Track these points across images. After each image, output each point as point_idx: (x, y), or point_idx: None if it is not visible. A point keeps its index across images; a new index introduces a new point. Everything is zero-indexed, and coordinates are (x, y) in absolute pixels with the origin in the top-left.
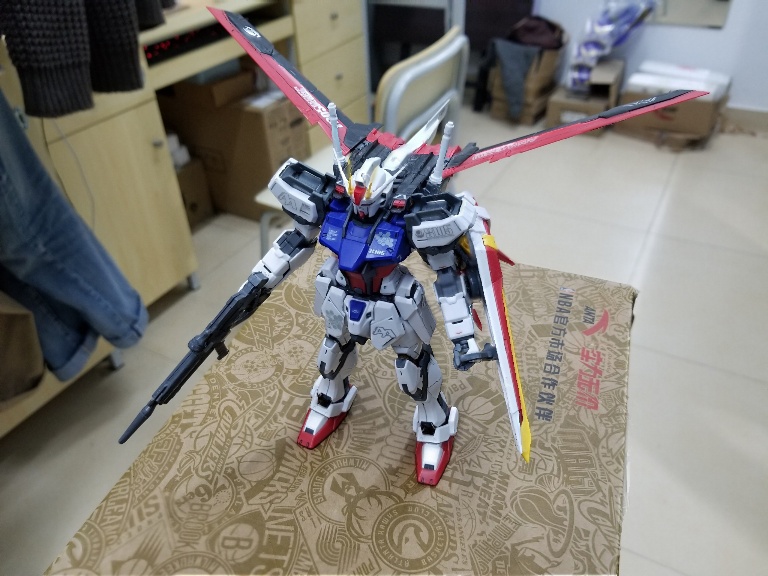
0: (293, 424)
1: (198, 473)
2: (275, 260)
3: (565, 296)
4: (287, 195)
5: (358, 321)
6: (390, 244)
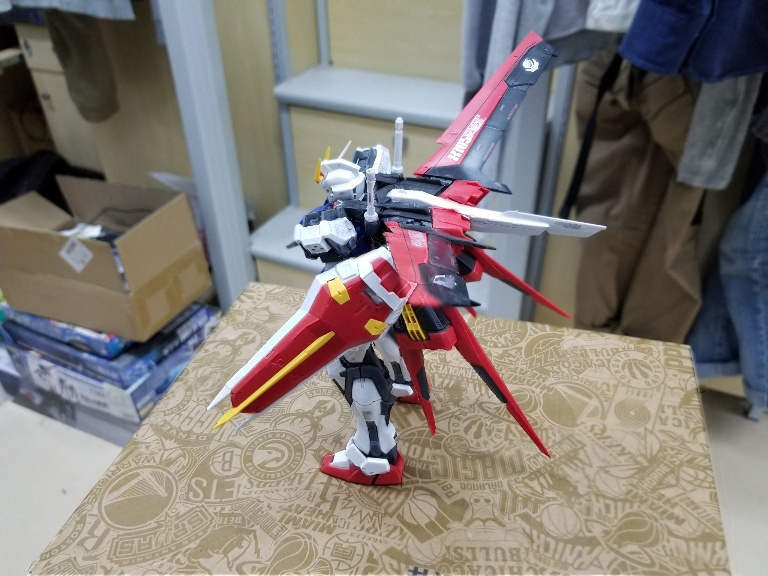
0: None
1: None
2: None
3: None
4: None
5: None
6: None
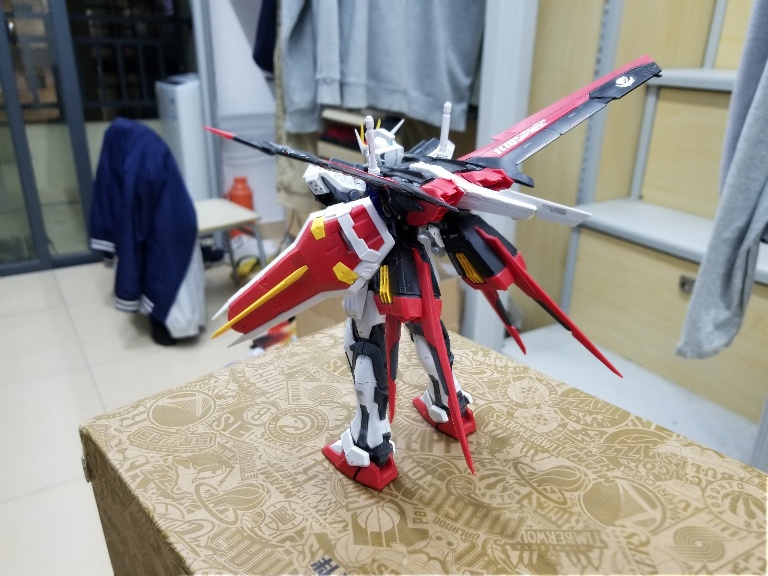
0: None
1: None
2: None
3: None
4: None
5: None
6: None
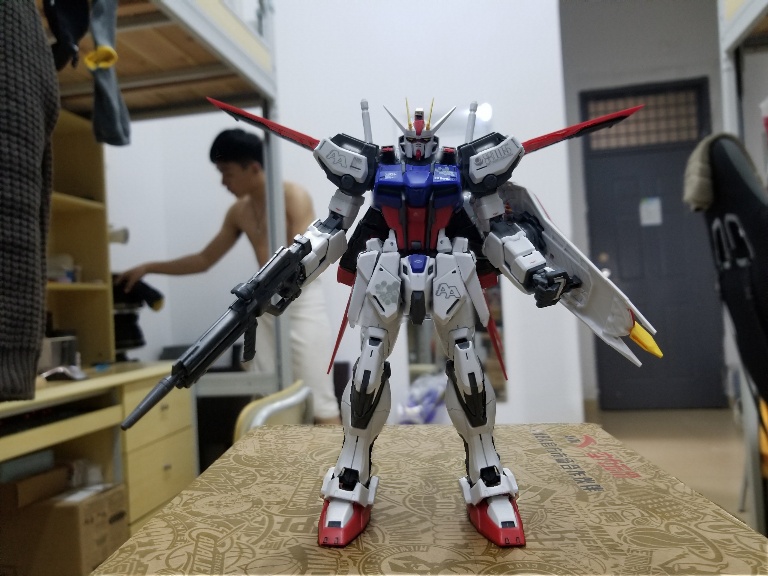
0: (303, 535)
1: None
2: (314, 239)
3: (539, 434)
4: (337, 152)
5: (422, 272)
6: (452, 174)
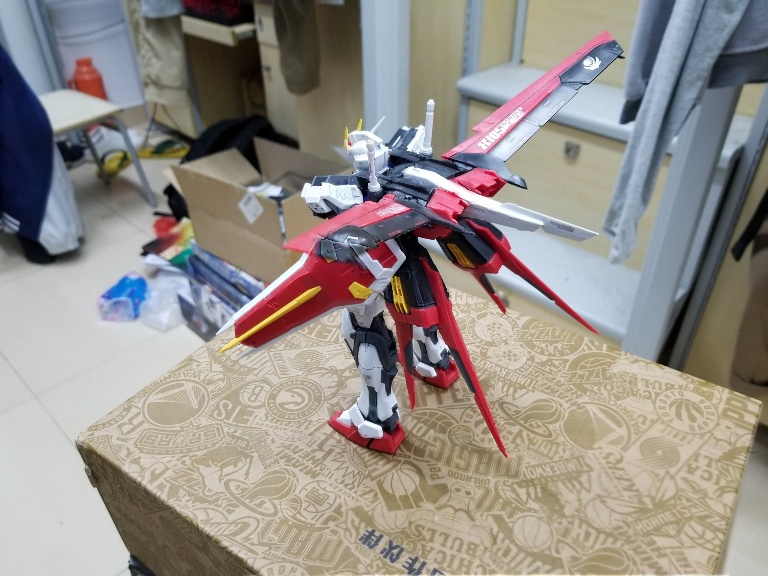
0: None
1: None
2: None
3: None
4: None
5: None
6: None
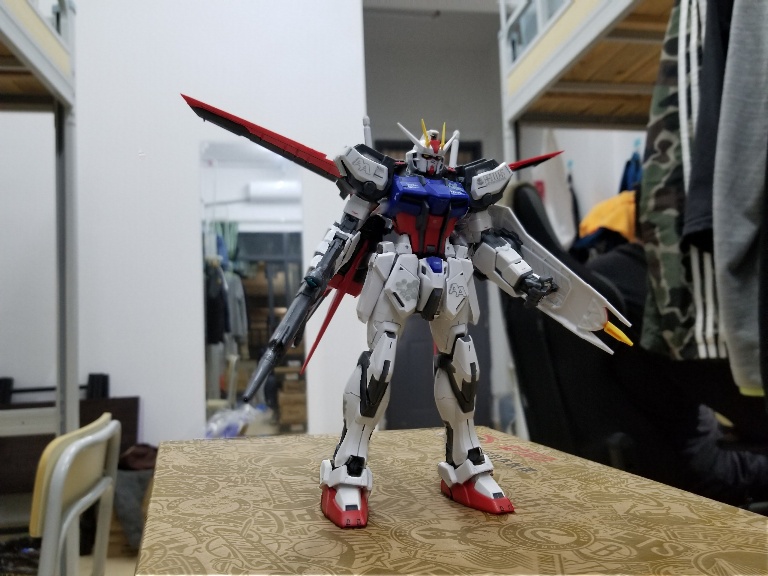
0: (317, 522)
1: (253, 568)
2: None
3: None
4: (362, 160)
5: (441, 272)
6: (461, 190)
